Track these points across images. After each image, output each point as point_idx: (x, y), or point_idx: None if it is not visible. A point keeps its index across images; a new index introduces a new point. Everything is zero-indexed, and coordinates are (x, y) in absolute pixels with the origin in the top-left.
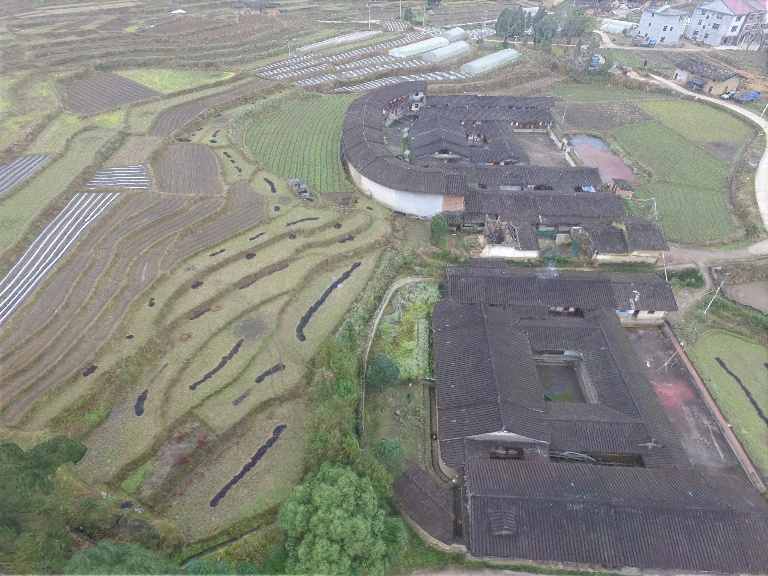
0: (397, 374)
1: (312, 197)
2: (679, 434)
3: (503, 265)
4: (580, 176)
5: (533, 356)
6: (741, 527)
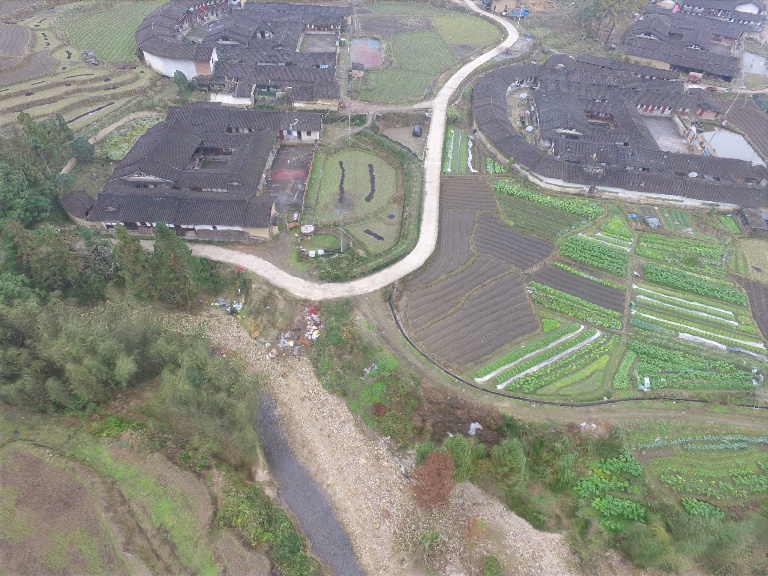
0: (90, 148)
1: (99, 63)
2: (277, 191)
3: (217, 105)
4: (321, 58)
5: (213, 156)
6: (249, 208)
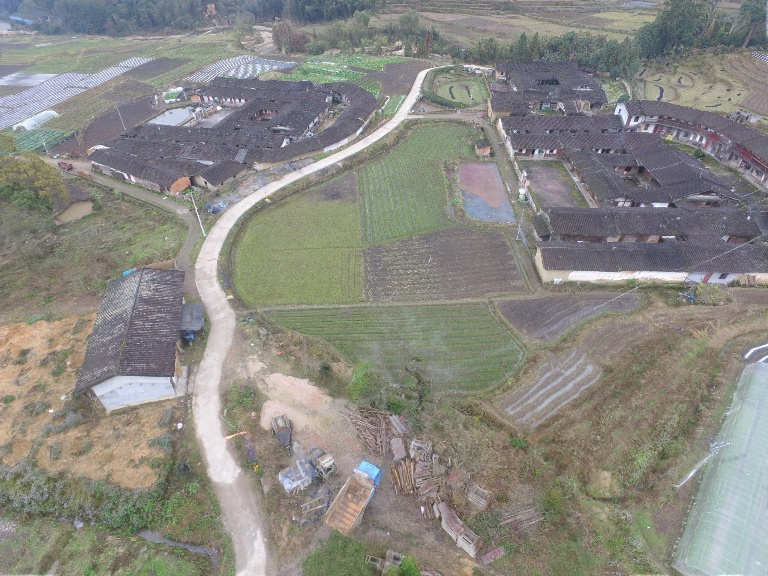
0: None
1: None
2: None
3: None
4: None
5: None
6: None
